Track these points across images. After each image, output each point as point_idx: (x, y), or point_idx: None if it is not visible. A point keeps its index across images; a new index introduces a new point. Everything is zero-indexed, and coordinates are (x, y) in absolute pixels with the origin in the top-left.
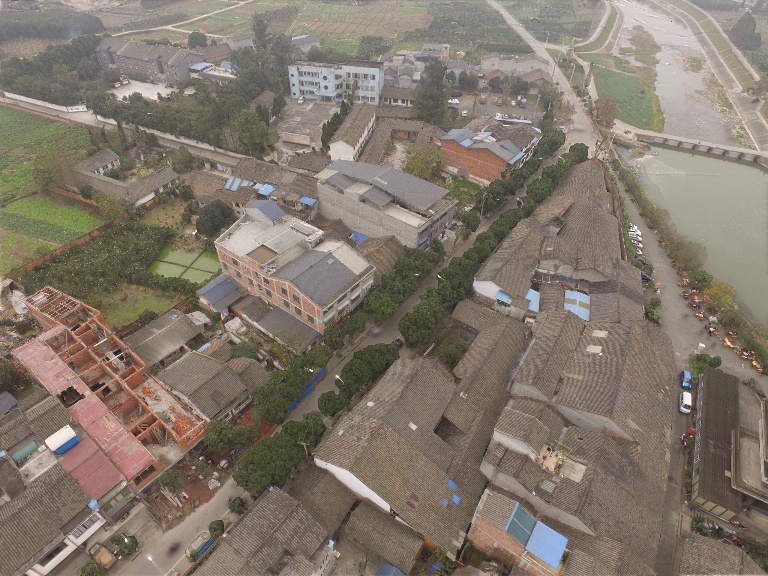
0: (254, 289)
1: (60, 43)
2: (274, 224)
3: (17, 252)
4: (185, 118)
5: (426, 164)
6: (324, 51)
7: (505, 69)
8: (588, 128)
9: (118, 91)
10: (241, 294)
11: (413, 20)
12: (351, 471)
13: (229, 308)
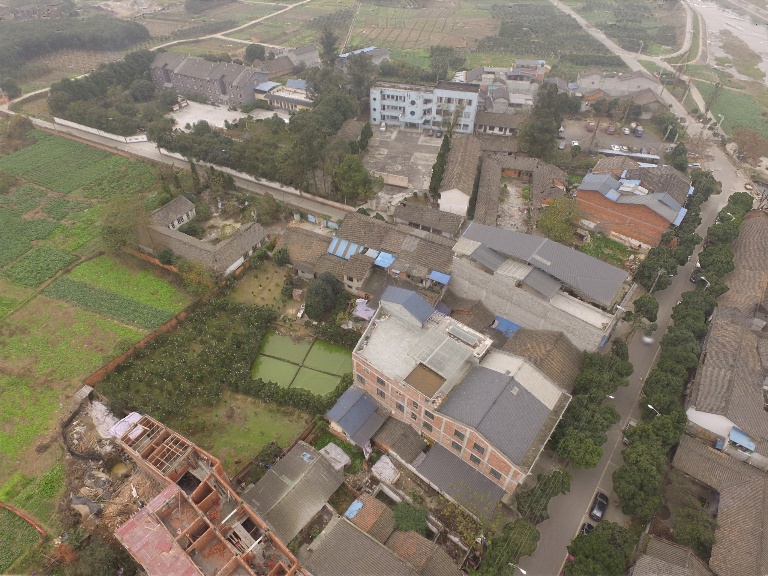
0: (402, 415)
1: (106, 55)
2: (423, 326)
3: (91, 340)
4: (268, 158)
5: (566, 222)
6: (396, 65)
7: (606, 88)
8: (726, 165)
9: (177, 115)
10: (383, 418)
11: (478, 25)
12: None
13: (371, 439)
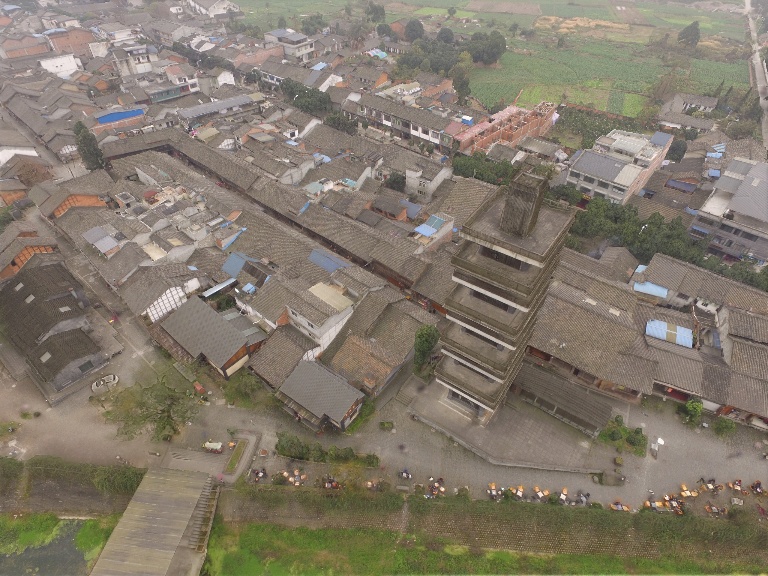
0: None
1: None
2: None
3: None
4: None
5: None
6: None
7: None
8: None
9: None
10: None
11: None
12: (460, 179)
13: None
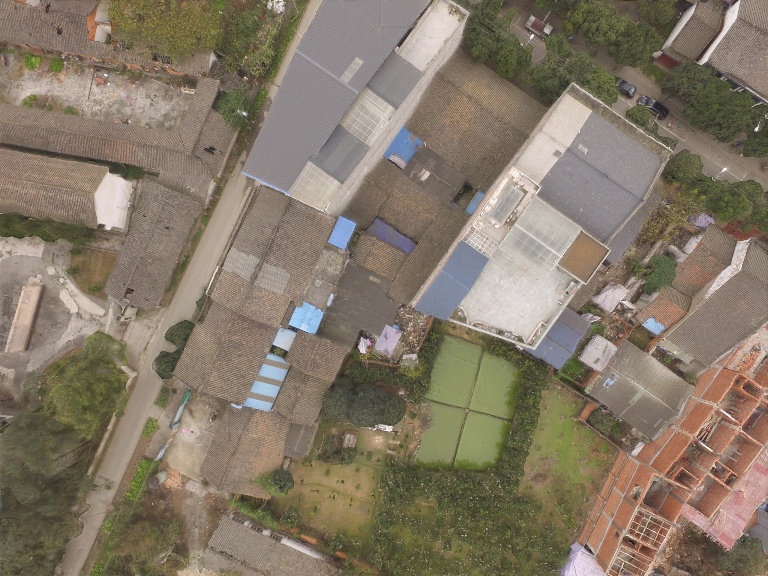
0: None
1: None
2: None
3: None
4: None
5: (182, 8)
6: None
7: None
8: None
9: None
10: None
11: None
12: None
13: None
